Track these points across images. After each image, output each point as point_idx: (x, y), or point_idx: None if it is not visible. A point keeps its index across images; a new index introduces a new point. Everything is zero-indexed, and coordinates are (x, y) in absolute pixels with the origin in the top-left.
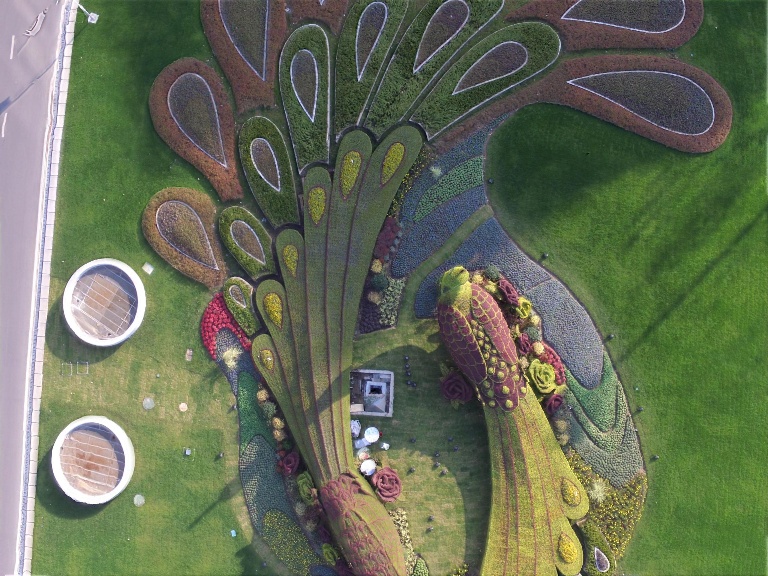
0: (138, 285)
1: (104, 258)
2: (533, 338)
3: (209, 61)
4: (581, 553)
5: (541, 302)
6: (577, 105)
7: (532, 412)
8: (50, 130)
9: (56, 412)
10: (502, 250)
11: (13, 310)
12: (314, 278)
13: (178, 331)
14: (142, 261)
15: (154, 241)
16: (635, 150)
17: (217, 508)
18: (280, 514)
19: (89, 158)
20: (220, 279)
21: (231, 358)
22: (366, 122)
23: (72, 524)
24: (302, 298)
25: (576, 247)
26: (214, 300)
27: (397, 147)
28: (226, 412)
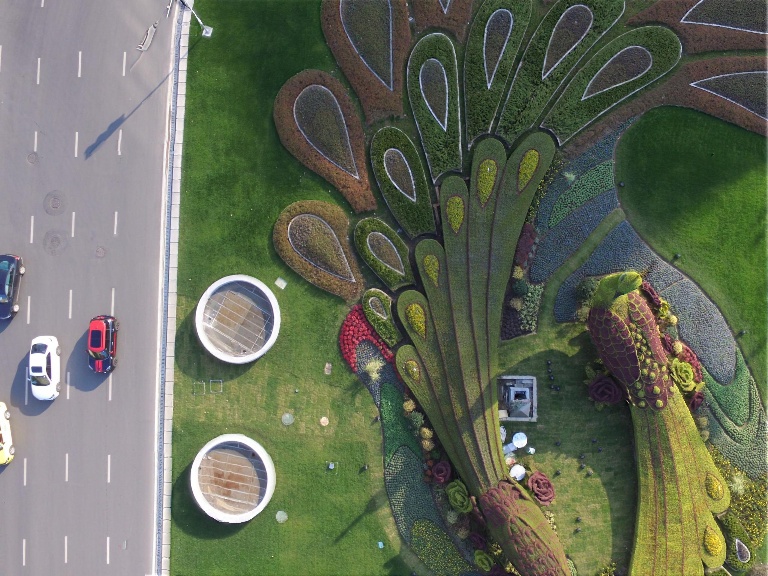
0: (274, 300)
1: (235, 274)
2: (673, 338)
3: (334, 72)
4: (724, 545)
5: (676, 302)
6: (701, 107)
7: (679, 410)
8: (168, 146)
9: (189, 432)
10: (636, 252)
11: (139, 330)
12: (458, 287)
13: (316, 345)
14: (275, 276)
15: (287, 255)
16: (757, 149)
17: (363, 520)
18: (428, 523)
19: (212, 173)
20: (358, 291)
21: (375, 370)
22: (498, 130)
23: (211, 544)
24: (446, 307)
25: (706, 246)
26: (353, 313)
27: (532, 154)
28: (369, 424)
